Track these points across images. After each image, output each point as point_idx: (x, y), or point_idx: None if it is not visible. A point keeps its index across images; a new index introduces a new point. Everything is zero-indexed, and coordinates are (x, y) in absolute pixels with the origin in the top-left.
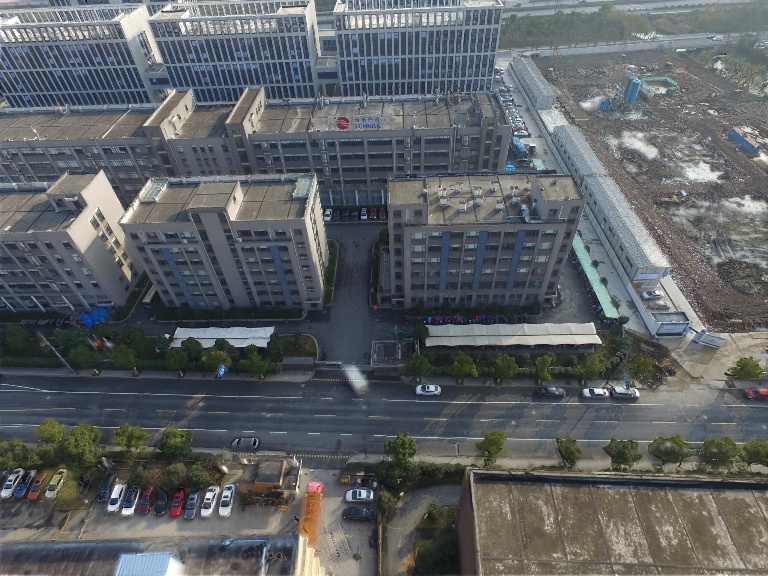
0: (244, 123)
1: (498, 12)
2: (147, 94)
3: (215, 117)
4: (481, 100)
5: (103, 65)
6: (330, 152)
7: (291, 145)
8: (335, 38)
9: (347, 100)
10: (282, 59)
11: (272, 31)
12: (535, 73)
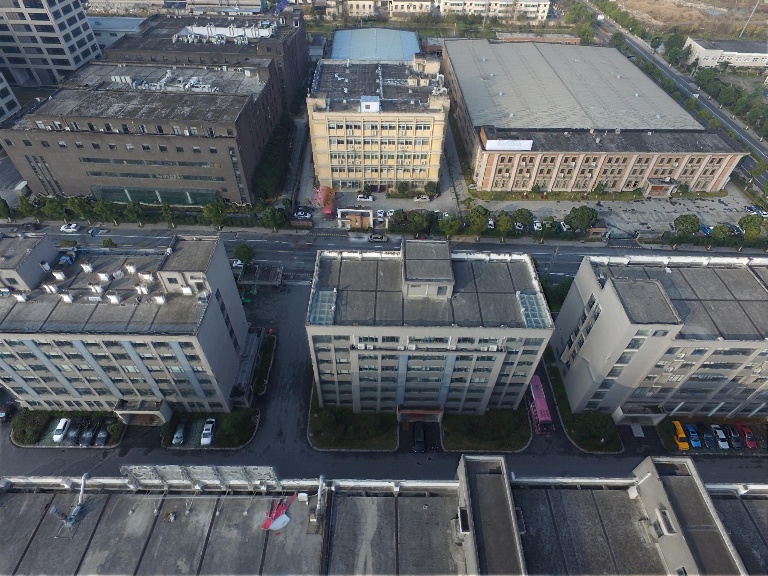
0: None
1: None
2: None
3: None
4: None
5: None
6: None
7: None
8: None
9: None
10: None
11: None
12: None
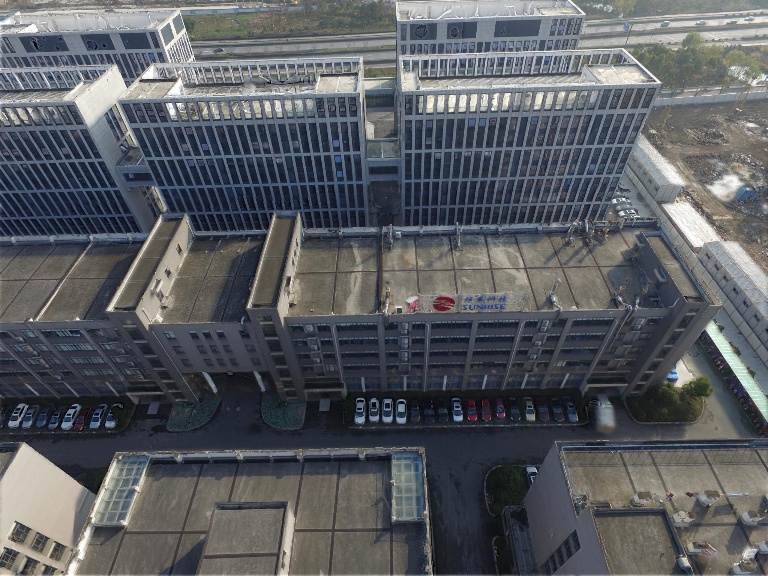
0: (278, 305)
1: (651, 92)
2: (121, 194)
3: (225, 264)
4: (658, 252)
5: (53, 158)
6: (414, 335)
7: (352, 327)
8: (401, 125)
9: (428, 230)
10: (320, 151)
11: (307, 115)
12: (642, 142)
